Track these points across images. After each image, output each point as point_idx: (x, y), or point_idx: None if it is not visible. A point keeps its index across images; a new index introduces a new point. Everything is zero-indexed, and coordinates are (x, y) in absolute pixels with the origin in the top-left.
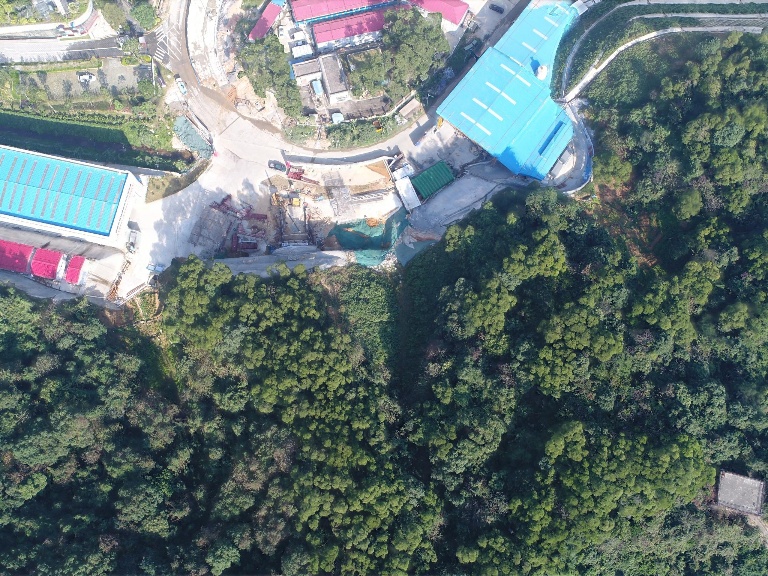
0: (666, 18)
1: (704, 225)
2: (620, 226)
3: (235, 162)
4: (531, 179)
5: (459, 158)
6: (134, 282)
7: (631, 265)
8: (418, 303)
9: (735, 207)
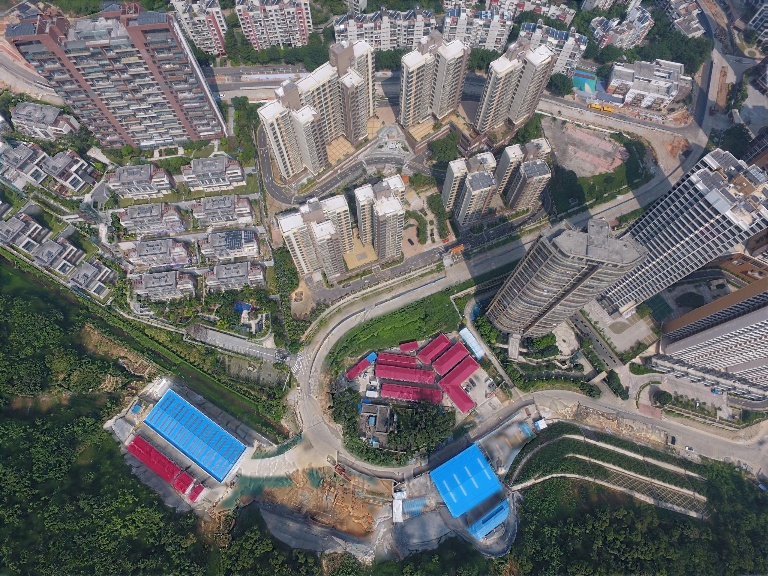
0: (589, 461)
1: None
2: None
3: (309, 449)
4: None
5: (436, 497)
6: (225, 506)
7: None
8: None
9: None
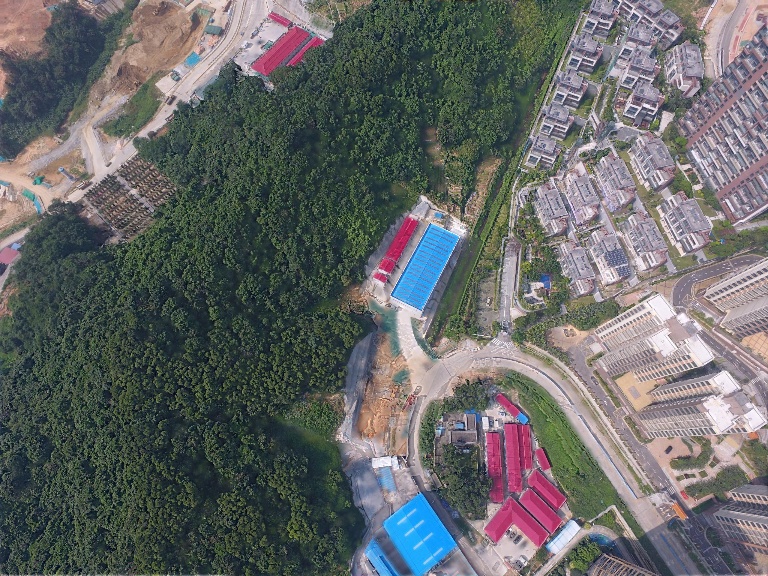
0: None
1: None
2: None
3: (425, 368)
4: None
5: (397, 503)
6: (371, 303)
7: None
8: (311, 446)
9: None
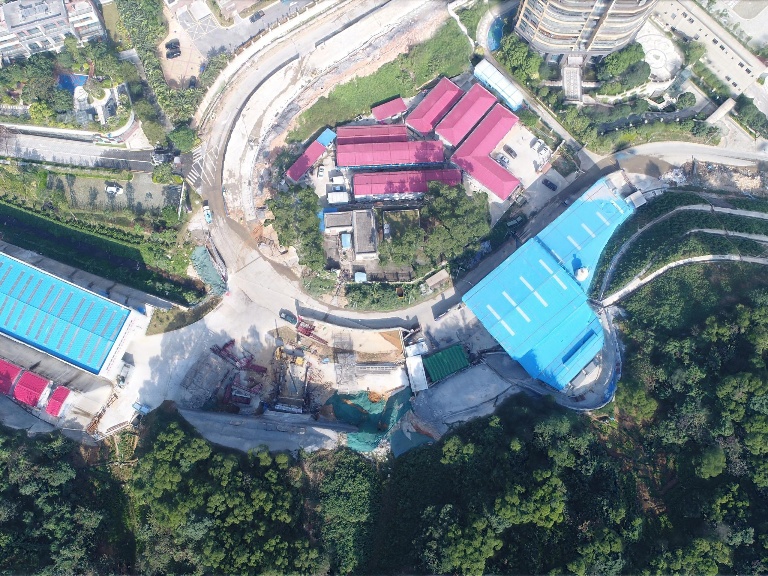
0: (727, 236)
1: (723, 490)
2: (634, 459)
3: (246, 305)
4: (549, 385)
5: (479, 342)
6: (117, 418)
7: (633, 528)
8: (402, 507)
9: (760, 480)
